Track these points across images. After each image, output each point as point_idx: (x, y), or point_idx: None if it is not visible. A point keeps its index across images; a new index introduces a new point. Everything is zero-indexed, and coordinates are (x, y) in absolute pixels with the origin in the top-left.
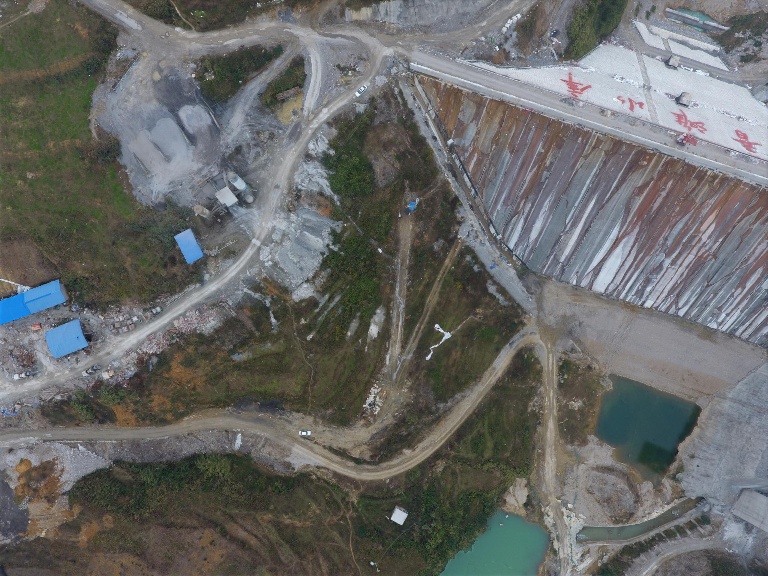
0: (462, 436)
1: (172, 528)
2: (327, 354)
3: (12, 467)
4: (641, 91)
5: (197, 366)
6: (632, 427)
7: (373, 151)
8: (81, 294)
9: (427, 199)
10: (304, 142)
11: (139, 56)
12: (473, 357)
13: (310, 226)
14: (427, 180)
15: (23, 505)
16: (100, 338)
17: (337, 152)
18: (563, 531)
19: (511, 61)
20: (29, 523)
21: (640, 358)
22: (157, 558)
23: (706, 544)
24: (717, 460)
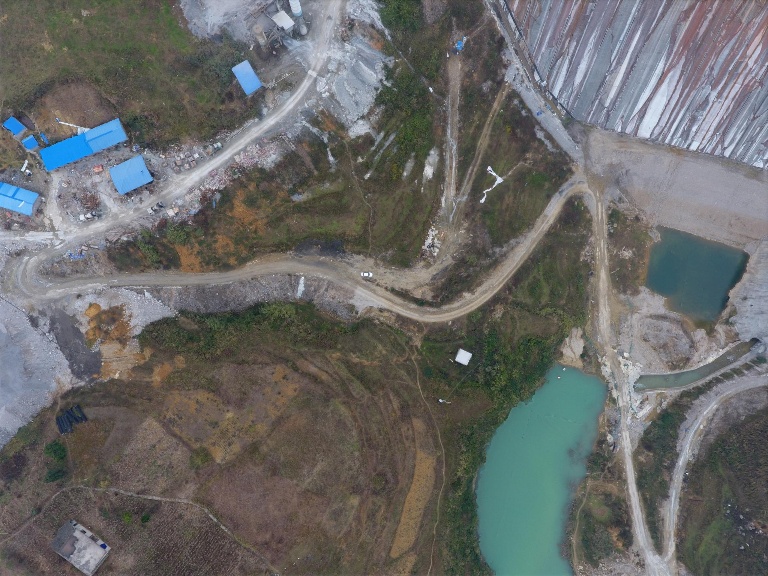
0: (519, 280)
1: (244, 364)
2: (385, 194)
3: (81, 312)
4: None
5: (258, 206)
6: (682, 278)
7: None
8: (141, 134)
9: (474, 37)
10: None
11: None
12: (525, 203)
13: (364, 57)
14: (474, 17)
15: (95, 347)
16: (162, 177)
17: None
18: (621, 380)
19: None
20: (102, 365)
21: (687, 205)
22: (231, 394)
23: (764, 381)
24: None
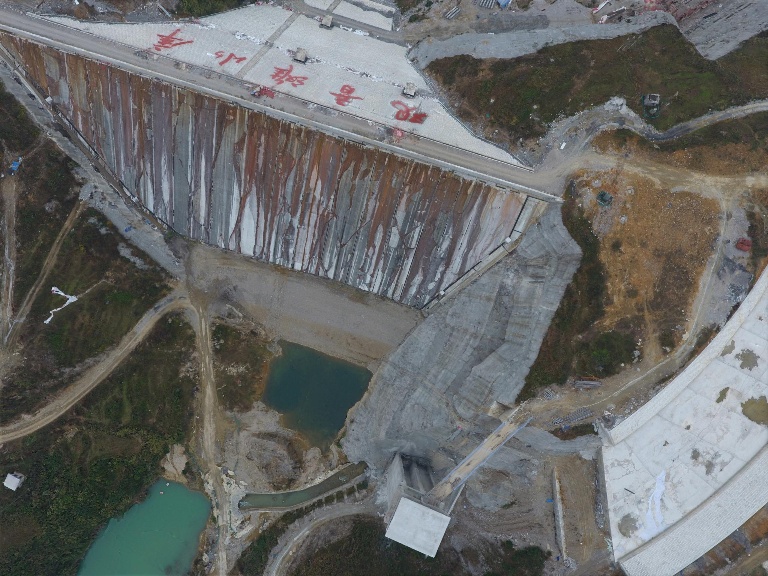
0: (92, 401)
1: None
2: None
3: None
4: (258, 47)
5: None
6: (303, 393)
7: None
8: None
9: (28, 158)
10: None
11: None
12: (107, 321)
13: None
14: (25, 139)
15: None
16: None
17: None
18: (223, 498)
19: (99, 16)
20: None
21: (302, 322)
22: None
23: (358, 508)
24: (365, 423)
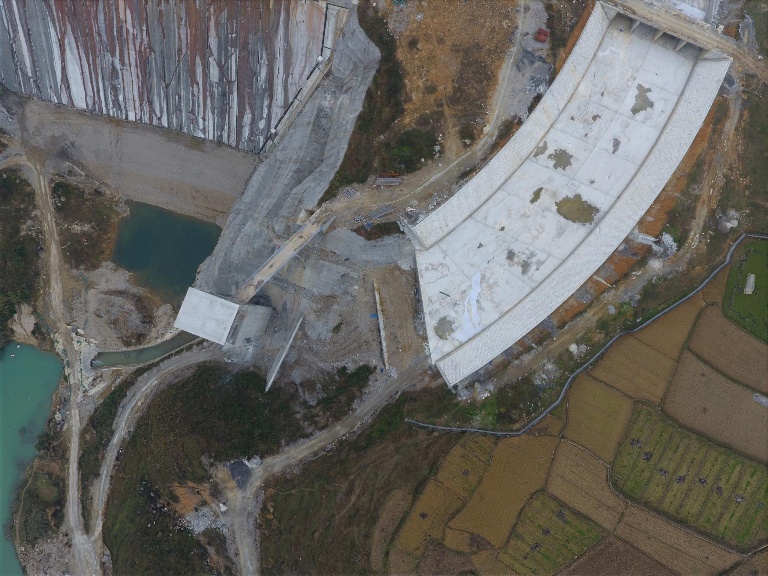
0: None
1: None
2: None
3: None
4: None
5: None
6: (154, 252)
7: None
8: None
9: None
10: None
11: None
12: None
13: None
14: None
15: None
16: None
17: None
18: (73, 357)
19: None
20: None
21: (145, 178)
22: None
23: (205, 355)
24: None
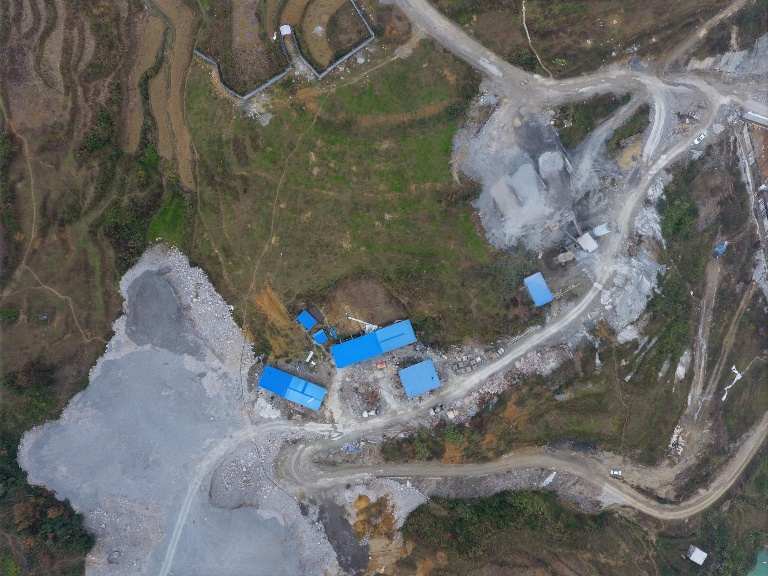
0: (749, 476)
1: (506, 567)
2: (641, 395)
3: (351, 503)
4: None
5: (525, 405)
6: None
7: (701, 197)
8: (426, 334)
9: (737, 243)
10: (643, 188)
11: (501, 102)
12: (757, 397)
13: (646, 270)
14: (740, 225)
15: (364, 541)
16: (443, 377)
17: (668, 197)
18: None
19: None
20: (370, 559)
21: None
22: None
23: None
24: None
